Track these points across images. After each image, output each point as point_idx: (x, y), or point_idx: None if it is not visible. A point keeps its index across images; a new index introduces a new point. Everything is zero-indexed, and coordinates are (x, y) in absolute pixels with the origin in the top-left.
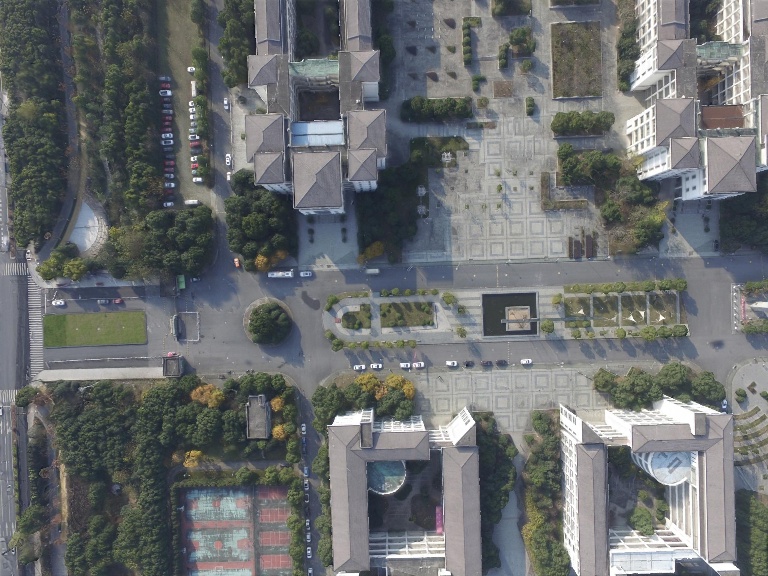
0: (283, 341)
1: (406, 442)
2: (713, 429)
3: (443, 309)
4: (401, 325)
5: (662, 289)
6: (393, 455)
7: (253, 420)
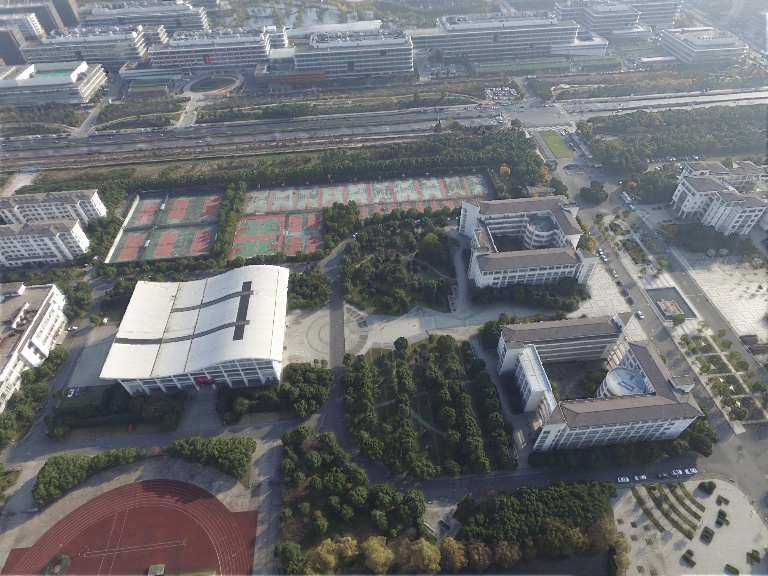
0: (586, 202)
1: (573, 223)
2: (682, 397)
3: (650, 268)
4: (628, 246)
5: (765, 398)
6: (561, 219)
7: (538, 188)
